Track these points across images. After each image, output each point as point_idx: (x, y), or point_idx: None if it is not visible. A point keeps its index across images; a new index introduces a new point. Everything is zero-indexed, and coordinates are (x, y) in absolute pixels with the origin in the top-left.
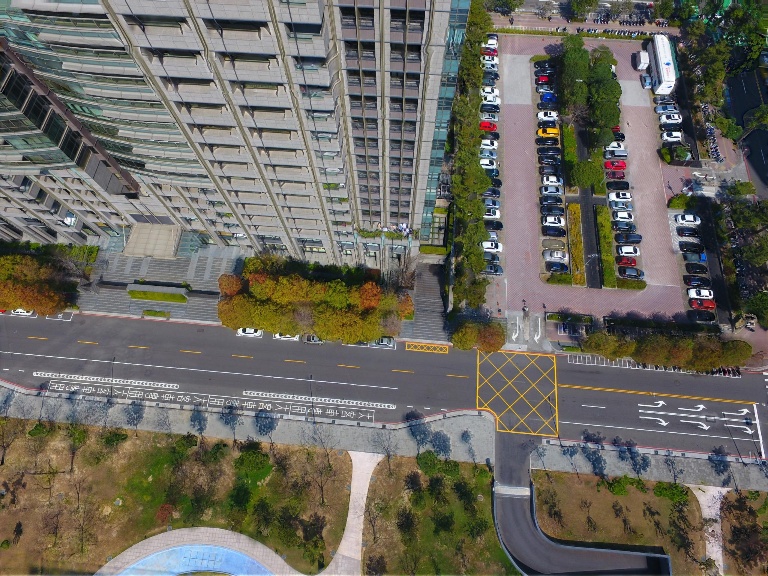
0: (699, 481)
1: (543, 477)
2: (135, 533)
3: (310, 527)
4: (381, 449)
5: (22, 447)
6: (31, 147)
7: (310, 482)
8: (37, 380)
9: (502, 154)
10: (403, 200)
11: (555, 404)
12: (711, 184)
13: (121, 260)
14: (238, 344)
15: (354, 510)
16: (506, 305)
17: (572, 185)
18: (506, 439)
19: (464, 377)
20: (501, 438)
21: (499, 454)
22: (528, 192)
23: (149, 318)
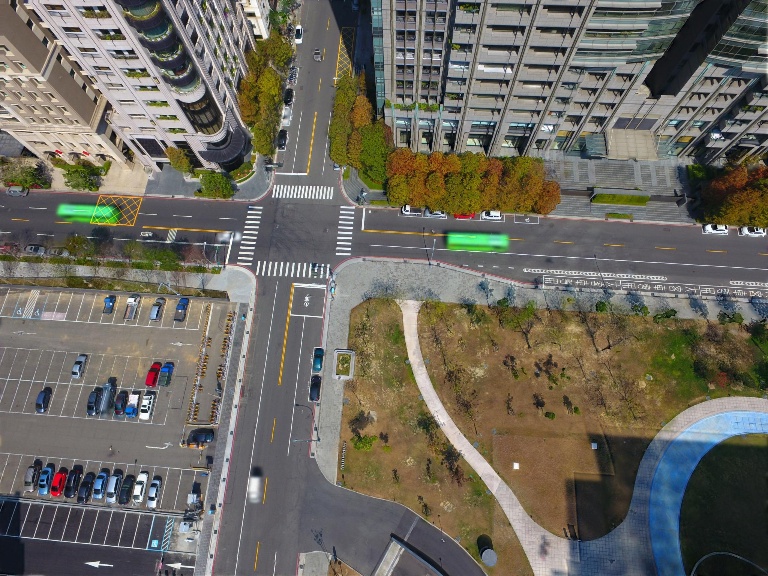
0: None
1: None
2: (678, 402)
3: None
4: None
5: (542, 332)
6: None
7: None
8: (530, 275)
9: None
10: None
11: None
12: None
13: (567, 170)
14: (708, 241)
15: None
16: None
17: None
18: None
19: None
20: None
21: None
22: None
23: (613, 220)
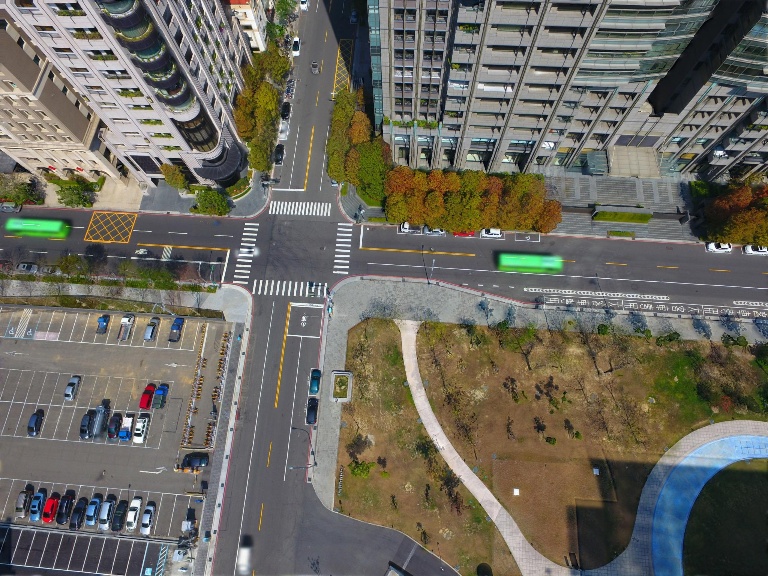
0: None
1: None
2: (681, 426)
3: None
4: None
5: (543, 354)
6: (659, 54)
7: None
8: (530, 295)
9: None
10: None
11: None
12: None
13: (568, 186)
14: (711, 259)
15: None
16: None
17: None
18: None
19: None
20: None
21: None
22: None
23: (615, 238)
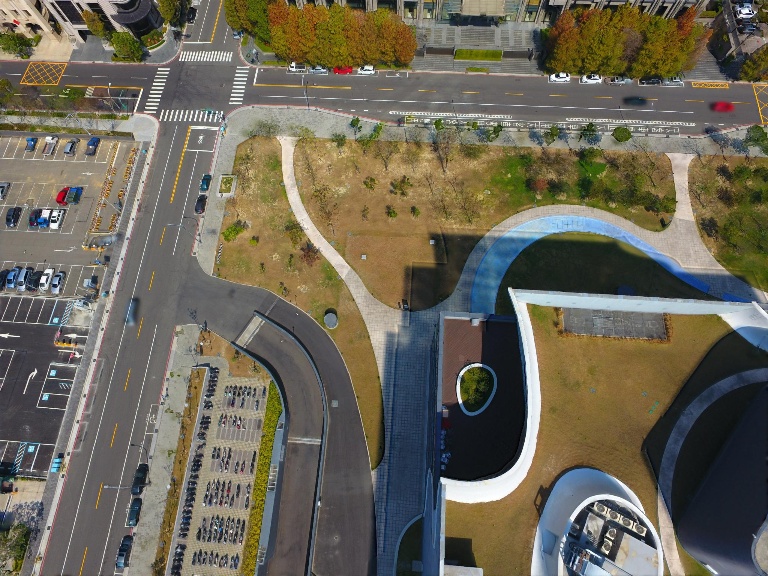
0: None
1: None
2: (509, 210)
3: None
4: (691, 151)
5: (399, 159)
6: None
7: (639, 174)
8: (394, 116)
9: None
10: None
11: None
12: None
13: (436, 34)
14: (552, 88)
15: (680, 191)
16: None
17: None
18: None
19: (746, 103)
20: None
21: None
22: None
23: (472, 73)
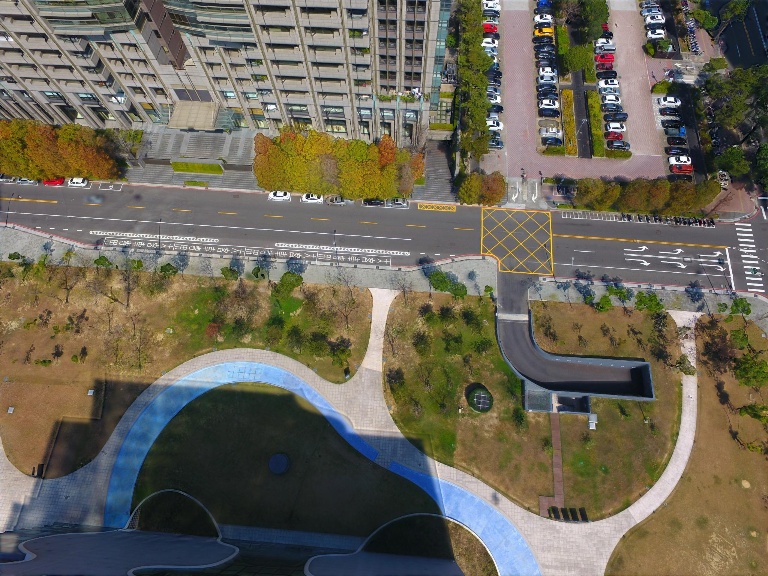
0: None
1: (540, 306)
2: (185, 353)
3: (337, 347)
4: (398, 286)
5: (83, 289)
6: (100, 2)
7: (336, 313)
8: (93, 237)
9: (502, 51)
10: (416, 56)
11: (550, 250)
12: (691, 73)
13: (163, 141)
14: (269, 207)
15: (375, 334)
16: (507, 173)
17: (565, 74)
18: (507, 277)
19: (470, 230)
20: (503, 277)
21: (501, 289)
22: (526, 82)
23: (190, 187)
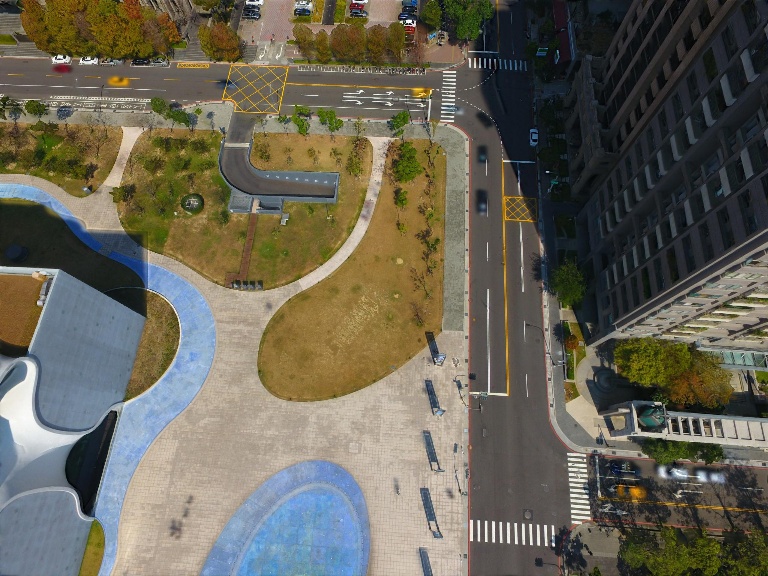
0: (376, 134)
1: (262, 137)
2: None
3: (86, 171)
4: (146, 125)
5: None
6: None
7: (90, 146)
8: None
9: None
10: None
11: (281, 95)
12: None
13: None
14: (52, 69)
15: (120, 161)
16: (259, 38)
17: None
18: (240, 116)
19: (217, 82)
20: (236, 116)
21: (232, 125)
22: None
23: None
